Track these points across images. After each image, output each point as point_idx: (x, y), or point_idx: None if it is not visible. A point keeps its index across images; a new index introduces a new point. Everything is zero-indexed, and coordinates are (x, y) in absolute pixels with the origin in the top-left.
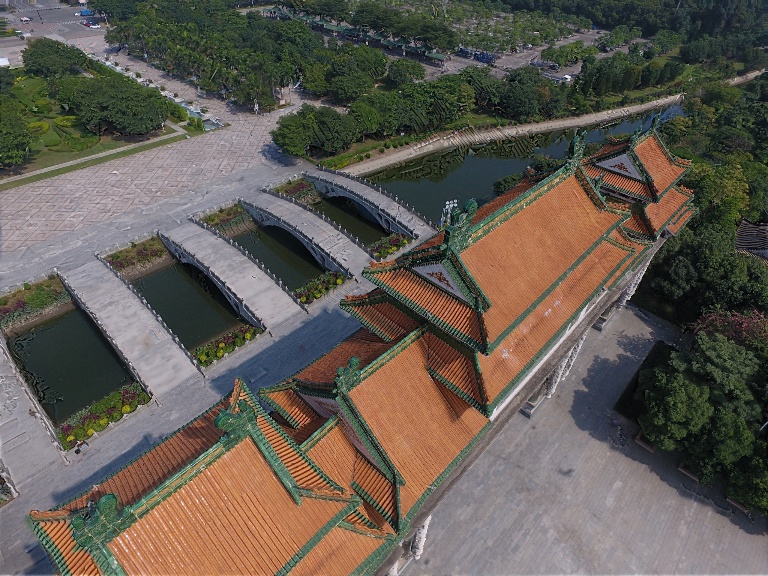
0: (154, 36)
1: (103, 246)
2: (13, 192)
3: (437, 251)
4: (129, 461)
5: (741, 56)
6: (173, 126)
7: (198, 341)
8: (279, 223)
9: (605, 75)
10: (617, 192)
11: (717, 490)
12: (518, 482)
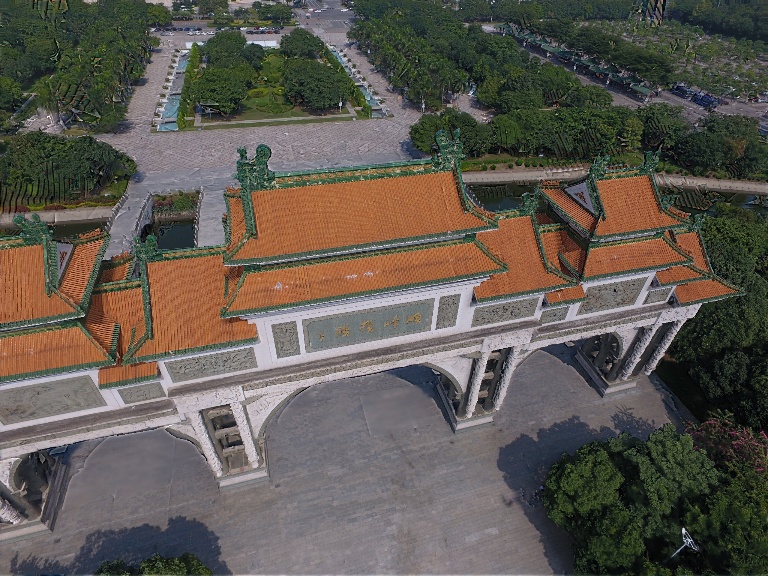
0: (377, 36)
1: None
2: (217, 132)
3: None
4: None
5: None
6: (350, 109)
7: None
8: None
9: None
10: None
11: None
12: (399, 475)
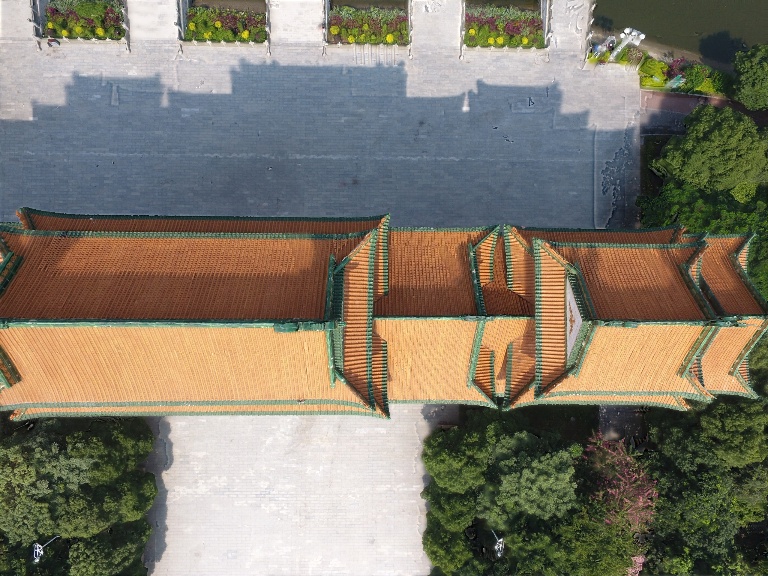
0: None
1: None
2: None
3: None
4: (80, 87)
5: None
6: None
7: None
8: None
9: None
10: None
11: None
12: None
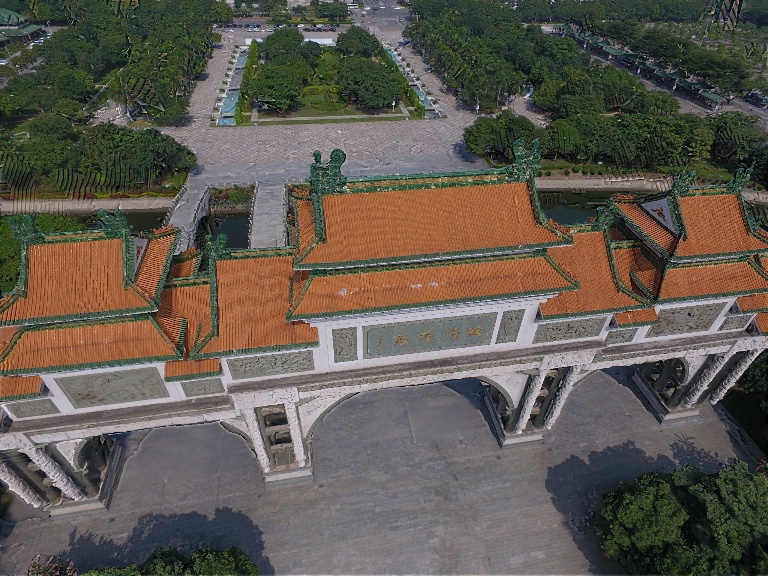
0: (433, 35)
1: (294, 178)
2: (272, 128)
3: None
4: None
5: None
6: (403, 108)
7: None
8: None
9: None
10: None
11: None
12: (443, 486)
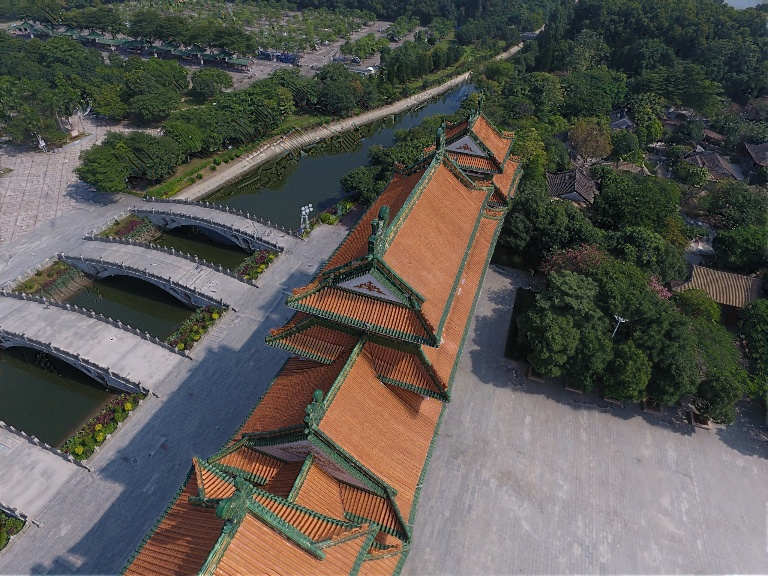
0: None
1: None
2: None
3: (361, 263)
4: None
5: (502, 35)
6: None
7: (62, 433)
8: (121, 271)
9: (404, 63)
10: (467, 170)
11: (596, 395)
12: (452, 450)
